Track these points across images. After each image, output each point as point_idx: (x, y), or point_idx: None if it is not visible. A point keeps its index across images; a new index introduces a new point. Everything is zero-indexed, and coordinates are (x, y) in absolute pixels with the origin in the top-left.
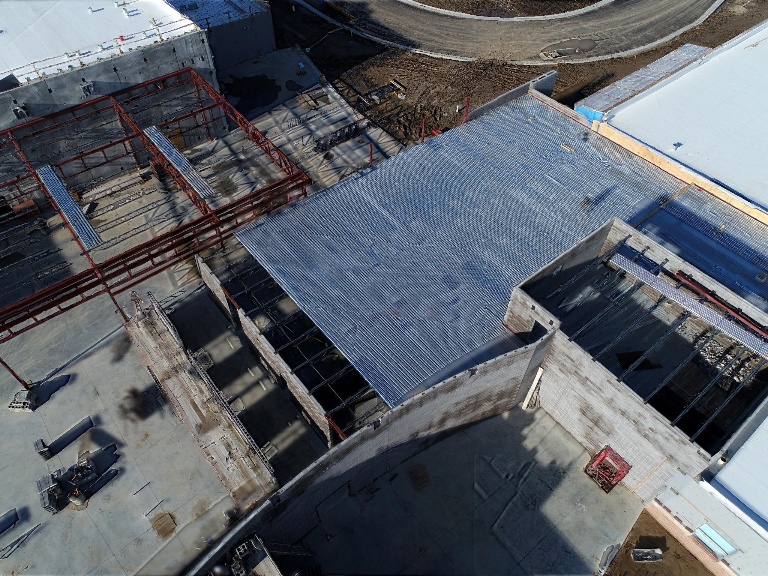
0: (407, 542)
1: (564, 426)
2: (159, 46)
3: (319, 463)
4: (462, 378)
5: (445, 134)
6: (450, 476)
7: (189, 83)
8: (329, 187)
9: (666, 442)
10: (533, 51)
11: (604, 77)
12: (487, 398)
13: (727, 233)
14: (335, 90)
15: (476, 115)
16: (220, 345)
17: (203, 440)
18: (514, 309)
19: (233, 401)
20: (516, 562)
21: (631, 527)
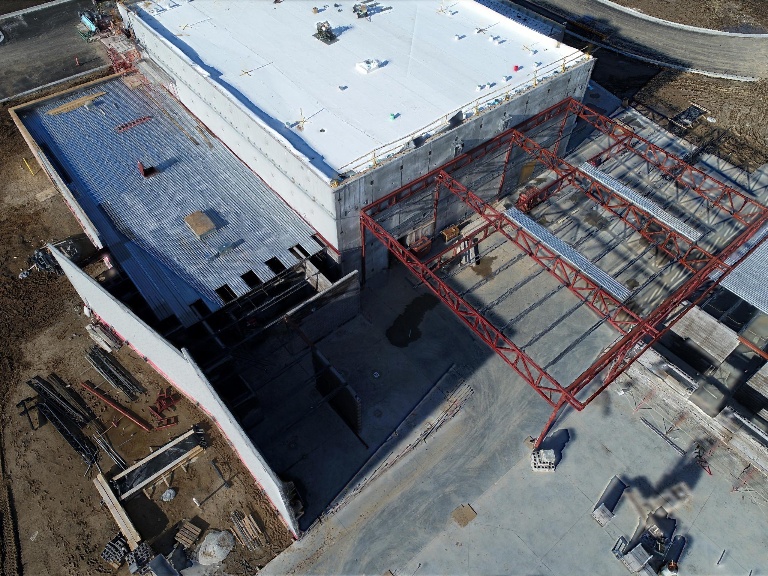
0: None
1: None
2: (562, 77)
3: None
4: None
5: None
6: None
7: (563, 113)
8: (766, 224)
9: None
10: None
11: None
12: None
13: None
14: (641, 114)
15: None
16: (701, 394)
17: None
18: None
19: None
20: None
21: None
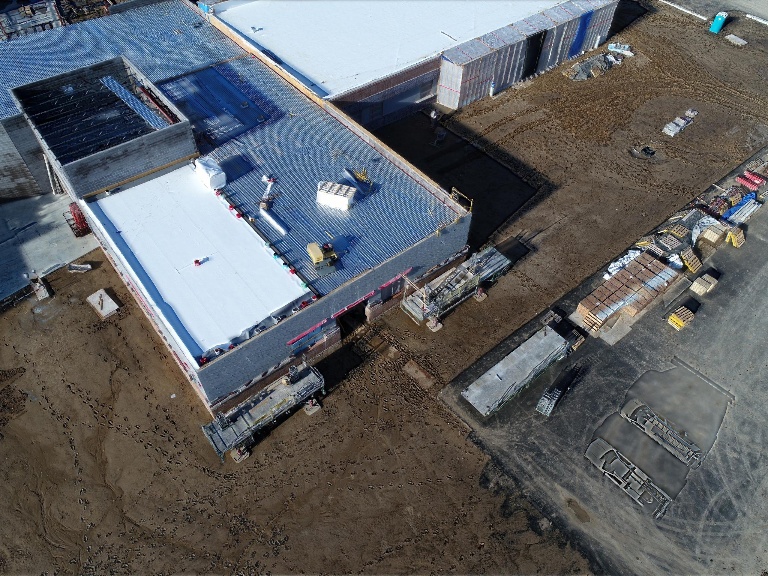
0: None
1: None
2: None
3: None
4: None
5: (86, 22)
6: None
7: None
8: None
9: (64, 177)
10: None
11: None
12: None
13: (247, 82)
14: (56, 4)
15: (120, 10)
16: None
17: None
18: None
19: None
20: None
21: (81, 255)
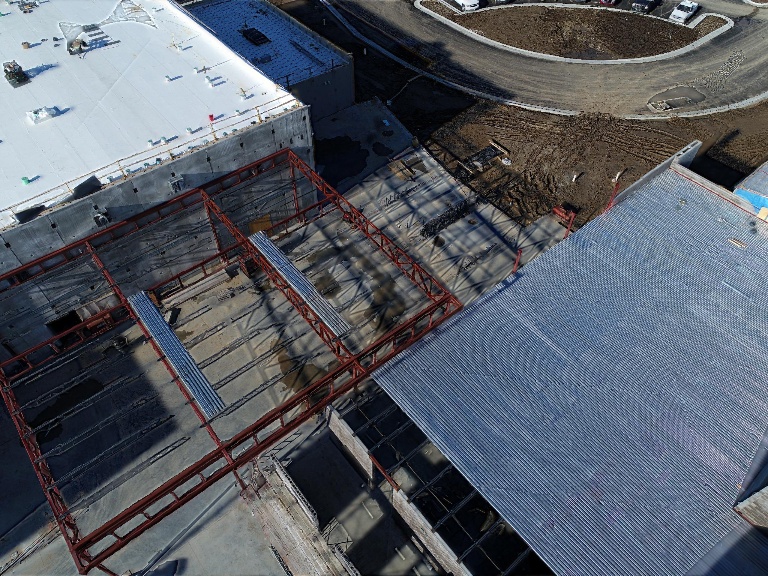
0: None
1: None
2: (258, 128)
3: None
4: None
5: (589, 225)
6: None
7: (285, 165)
8: (471, 303)
9: None
10: (639, 102)
11: (728, 135)
12: None
13: None
14: (430, 155)
15: (620, 199)
16: (356, 513)
17: None
18: (763, 502)
19: None
20: None
21: None
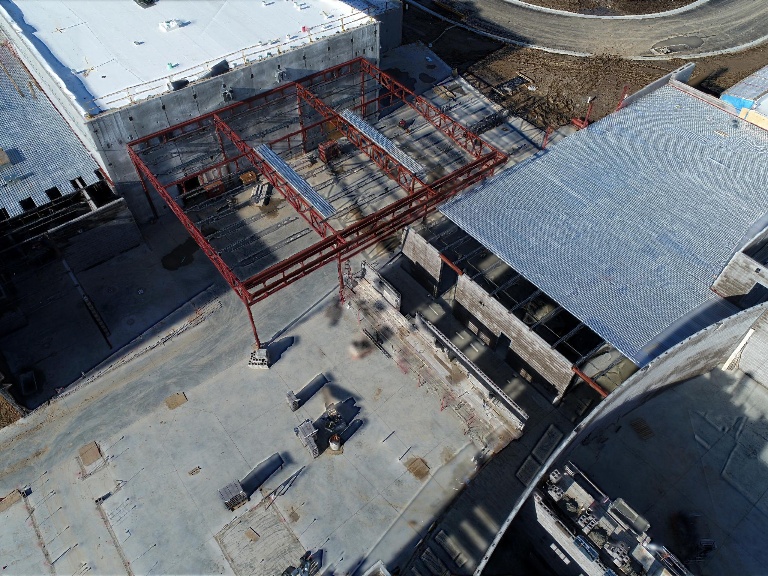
0: (646, 485)
1: (767, 385)
2: (341, 36)
3: (608, 401)
4: (710, 331)
5: (602, 120)
6: (670, 428)
7: None
8: None
9: None
10: (644, 47)
11: (719, 71)
12: (706, 356)
13: None
14: (467, 82)
15: (627, 103)
16: (425, 311)
17: (456, 390)
18: (730, 273)
19: (451, 361)
20: (752, 504)
21: None
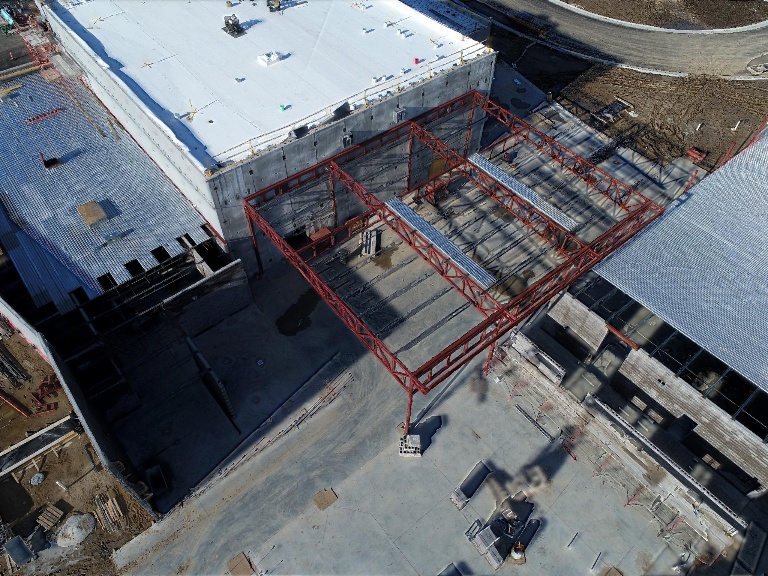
0: None
1: None
2: (460, 69)
3: None
4: None
5: (738, 157)
6: None
7: (468, 106)
8: None
9: None
10: (739, 65)
11: None
12: None
13: None
14: (564, 108)
15: (760, 137)
16: (579, 382)
17: (658, 491)
18: None
19: None
20: None
21: None
